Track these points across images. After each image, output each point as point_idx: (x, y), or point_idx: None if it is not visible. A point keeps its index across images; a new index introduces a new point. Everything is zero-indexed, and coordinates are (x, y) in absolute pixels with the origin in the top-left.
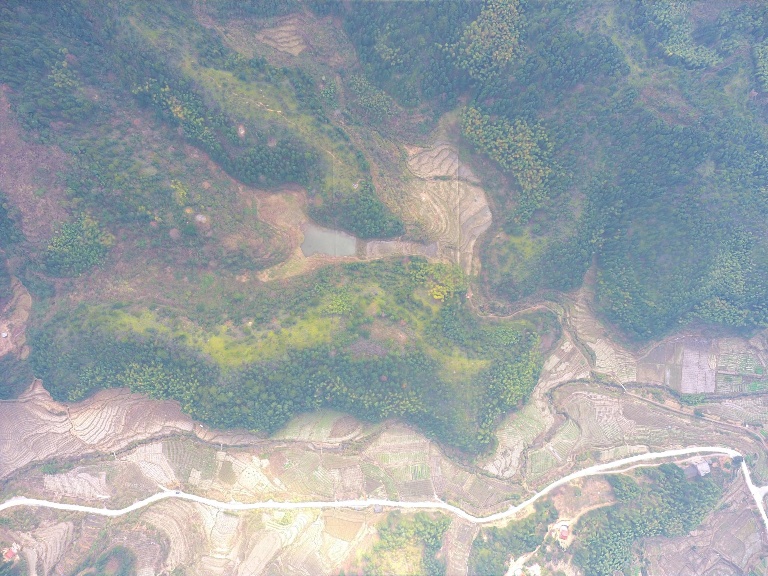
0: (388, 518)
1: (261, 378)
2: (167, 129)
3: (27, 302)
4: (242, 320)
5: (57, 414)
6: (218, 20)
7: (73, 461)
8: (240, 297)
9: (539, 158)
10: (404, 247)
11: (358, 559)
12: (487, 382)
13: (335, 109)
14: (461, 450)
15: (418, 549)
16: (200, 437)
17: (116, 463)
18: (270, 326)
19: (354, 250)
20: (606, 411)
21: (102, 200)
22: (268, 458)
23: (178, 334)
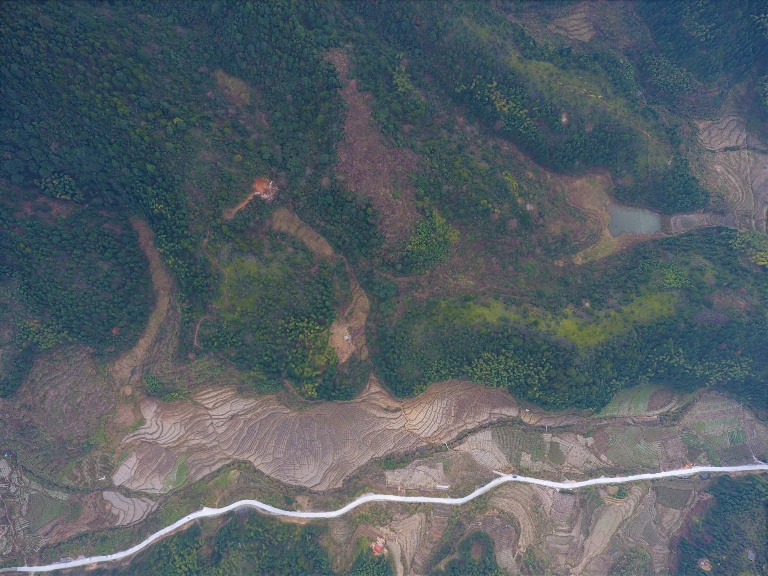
0: (721, 483)
1: (612, 356)
2: (479, 124)
3: (364, 304)
4: (582, 302)
5: (393, 411)
6: (513, 14)
7: (408, 455)
8: None
9: None
10: (705, 219)
11: (699, 525)
12: None
13: (637, 90)
14: None
15: (762, 509)
16: (526, 421)
17: (451, 453)
18: (610, 305)
19: (659, 226)
20: None
21: (446, 197)
22: (592, 436)
23: (530, 320)
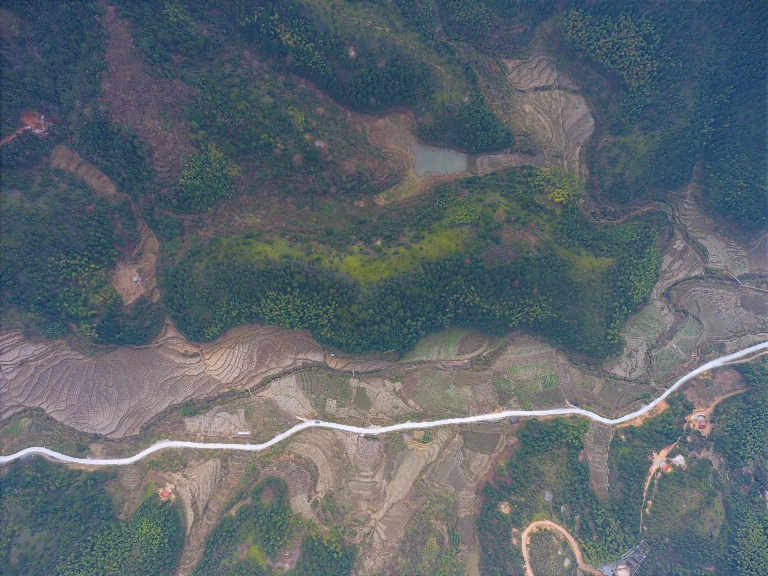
0: (527, 426)
1: (399, 293)
2: (273, 61)
3: (154, 245)
4: (372, 239)
5: (191, 356)
6: None
7: (210, 402)
8: (365, 219)
9: (646, 52)
10: (513, 159)
11: (503, 468)
12: (615, 280)
13: (436, 26)
14: (588, 355)
15: (563, 451)
16: (332, 366)
17: (253, 399)
18: (400, 242)
19: (465, 166)
20: (724, 304)
21: (225, 131)
22: (400, 381)
23: (313, 257)
